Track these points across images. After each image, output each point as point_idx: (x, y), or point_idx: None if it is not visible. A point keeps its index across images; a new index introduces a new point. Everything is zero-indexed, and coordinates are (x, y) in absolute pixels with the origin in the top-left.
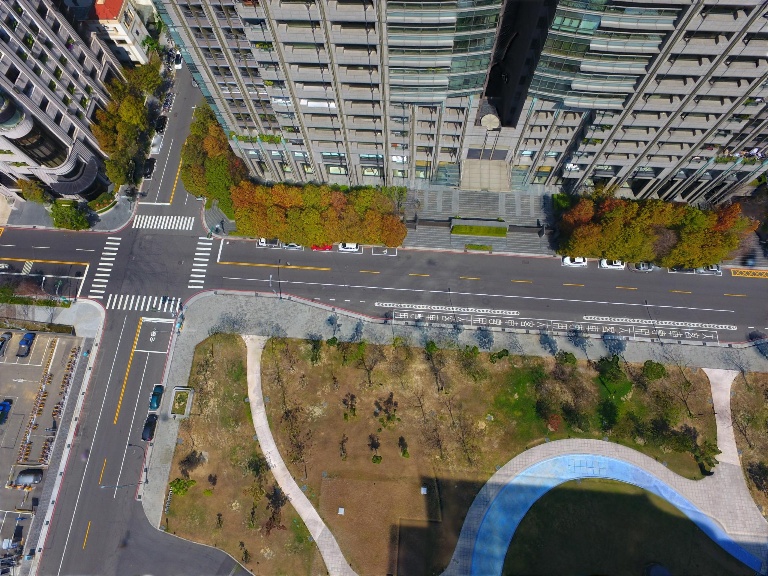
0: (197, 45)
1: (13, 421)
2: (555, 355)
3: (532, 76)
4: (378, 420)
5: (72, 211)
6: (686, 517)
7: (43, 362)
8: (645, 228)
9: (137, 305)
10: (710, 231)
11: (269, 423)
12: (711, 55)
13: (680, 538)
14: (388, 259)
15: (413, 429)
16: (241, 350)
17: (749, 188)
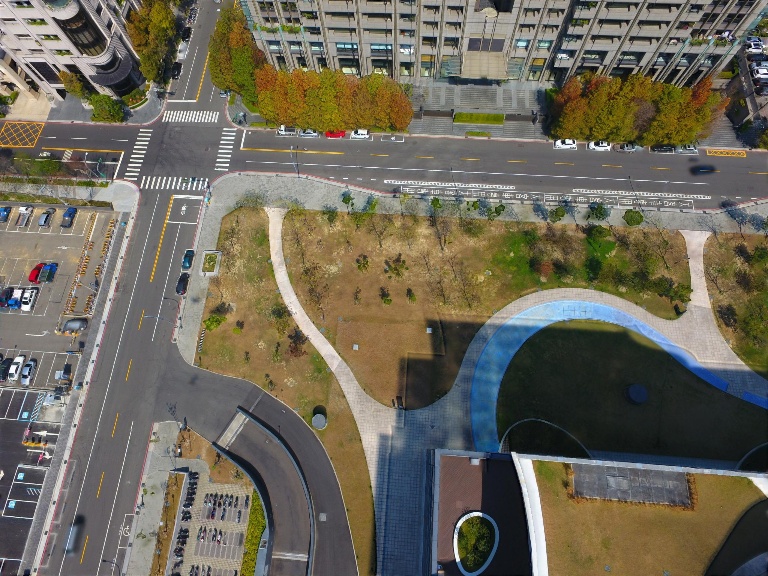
0: None
1: (59, 280)
2: (547, 221)
3: None
4: None
5: (110, 99)
6: (662, 349)
7: (85, 232)
8: (627, 102)
9: (168, 185)
10: (685, 103)
11: (290, 279)
12: None
13: (656, 366)
14: (396, 144)
15: (419, 282)
16: (264, 220)
17: (724, 80)
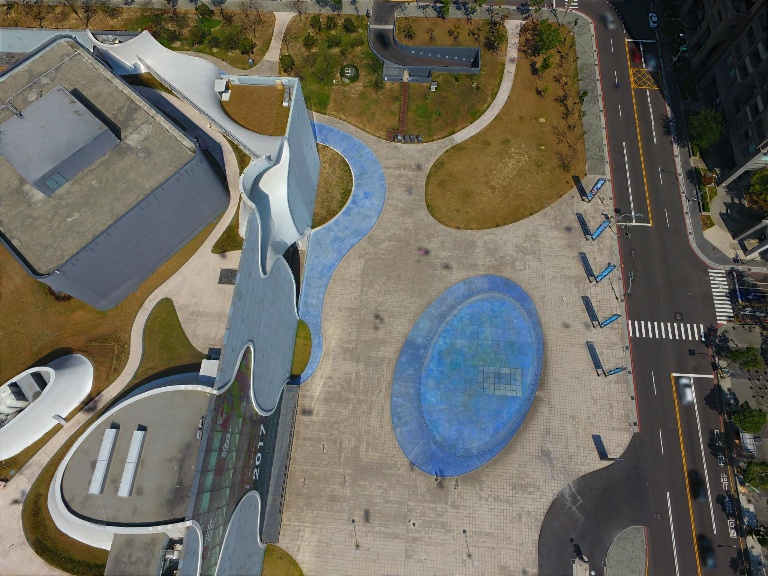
0: None
1: None
2: (174, 7)
3: None
4: None
5: None
6: None
7: None
8: None
9: None
10: None
11: None
12: None
13: None
14: None
15: None
16: None
17: None
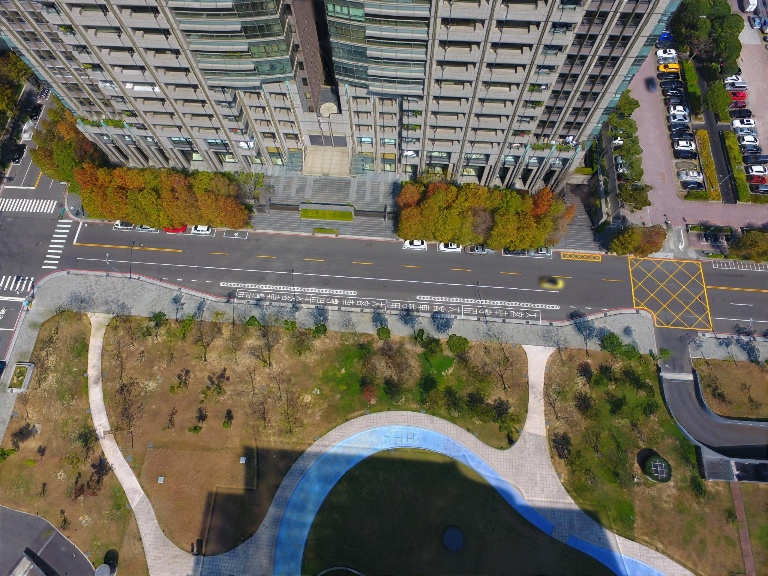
0: (11, 28)
1: None
2: None
3: (334, 62)
4: (209, 394)
5: None
6: (489, 484)
7: None
8: (465, 211)
9: None
10: (523, 213)
11: (104, 397)
12: (475, 42)
13: (480, 504)
14: (238, 241)
15: (241, 402)
16: (85, 327)
17: (585, 176)
